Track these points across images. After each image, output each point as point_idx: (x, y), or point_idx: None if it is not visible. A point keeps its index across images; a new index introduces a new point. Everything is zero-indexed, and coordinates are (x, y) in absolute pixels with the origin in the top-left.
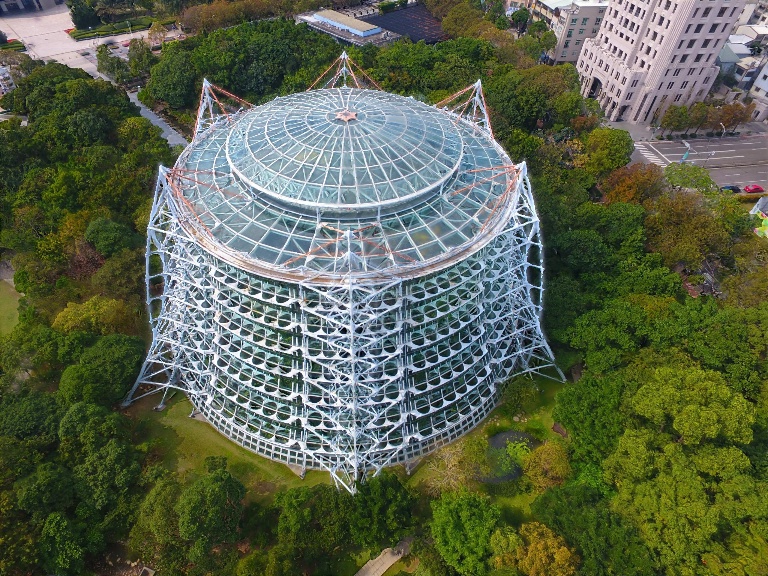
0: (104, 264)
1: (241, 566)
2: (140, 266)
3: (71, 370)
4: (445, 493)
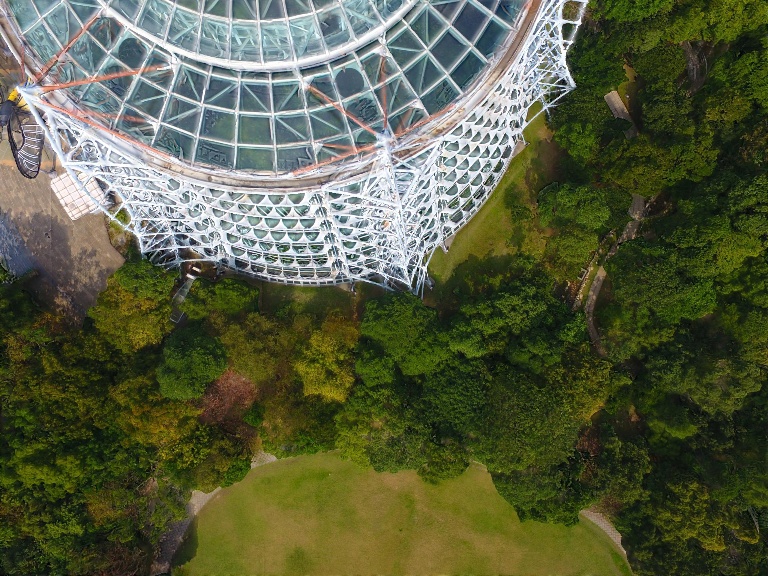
0: (231, 371)
1: (640, 172)
2: (248, 320)
3: (419, 358)
4: (591, 4)
